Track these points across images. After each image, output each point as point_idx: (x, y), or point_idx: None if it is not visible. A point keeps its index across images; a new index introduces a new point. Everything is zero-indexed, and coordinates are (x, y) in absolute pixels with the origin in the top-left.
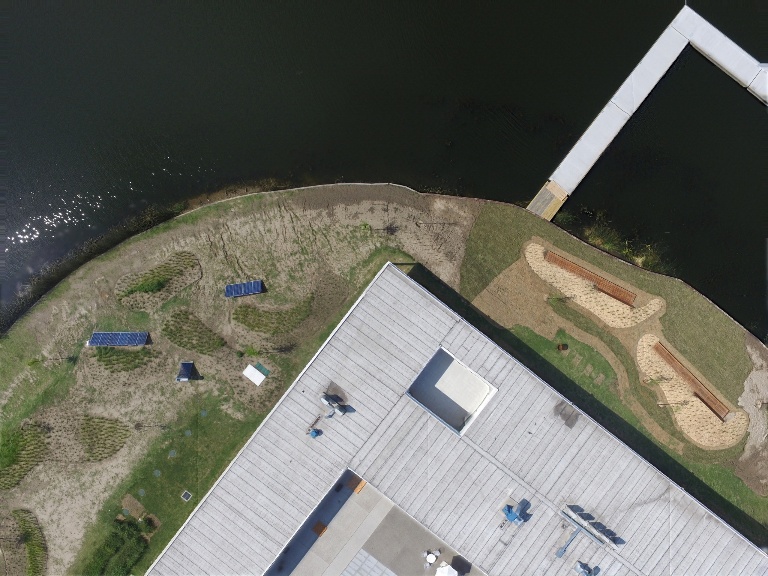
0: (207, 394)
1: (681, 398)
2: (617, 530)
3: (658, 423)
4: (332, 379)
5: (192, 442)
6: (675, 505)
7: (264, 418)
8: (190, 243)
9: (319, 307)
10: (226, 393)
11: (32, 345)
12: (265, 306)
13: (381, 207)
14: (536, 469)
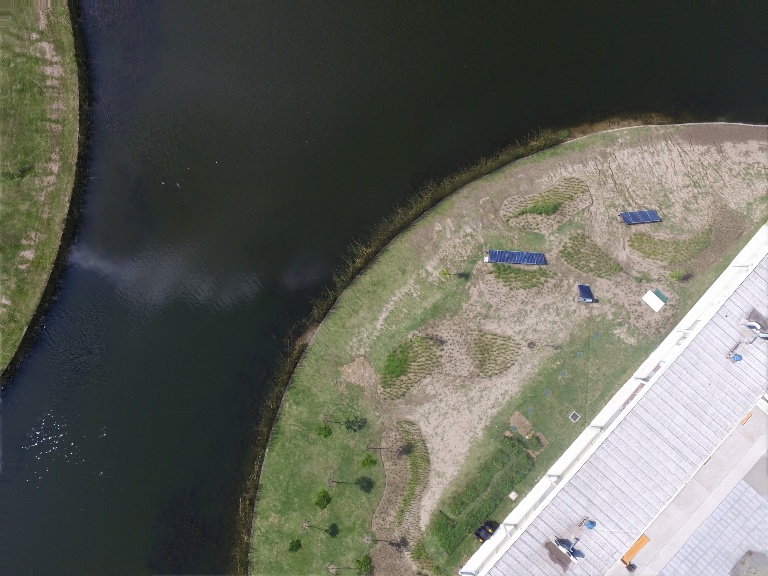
0: (601, 317)
1: None
2: None
3: None
4: (754, 306)
5: (584, 364)
6: None
7: (657, 345)
8: (578, 170)
9: (717, 239)
10: (621, 317)
11: (415, 260)
12: (660, 235)
13: None
14: None
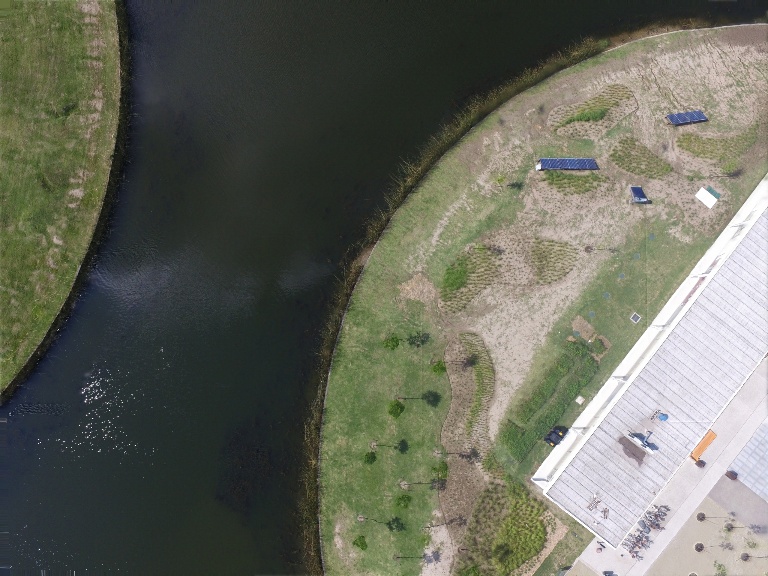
0: (655, 218)
1: None
2: None
3: None
4: None
5: (641, 265)
6: None
7: (712, 242)
8: (621, 77)
9: (764, 134)
10: (675, 217)
11: (466, 175)
12: (708, 134)
13: None
14: None
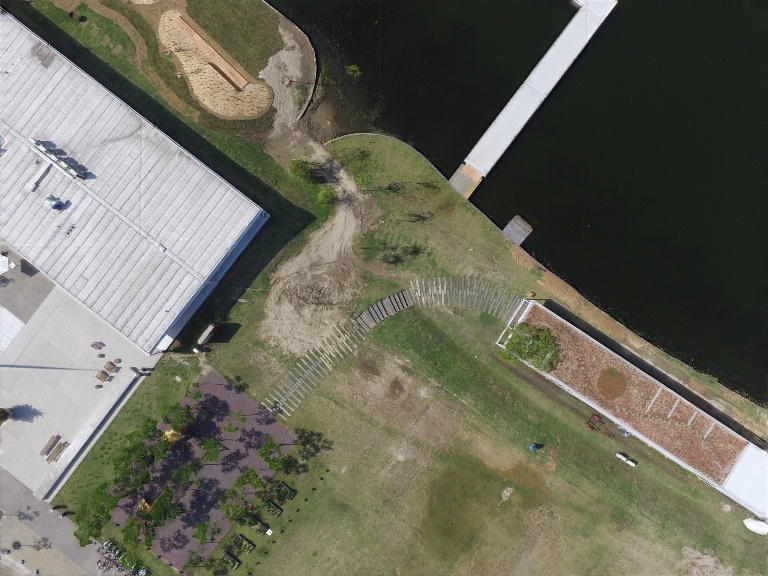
0: None
1: (196, 67)
2: (89, 165)
3: (175, 92)
4: None
5: None
6: (147, 142)
7: None
8: None
9: None
10: None
11: None
12: None
13: None
14: (11, 106)
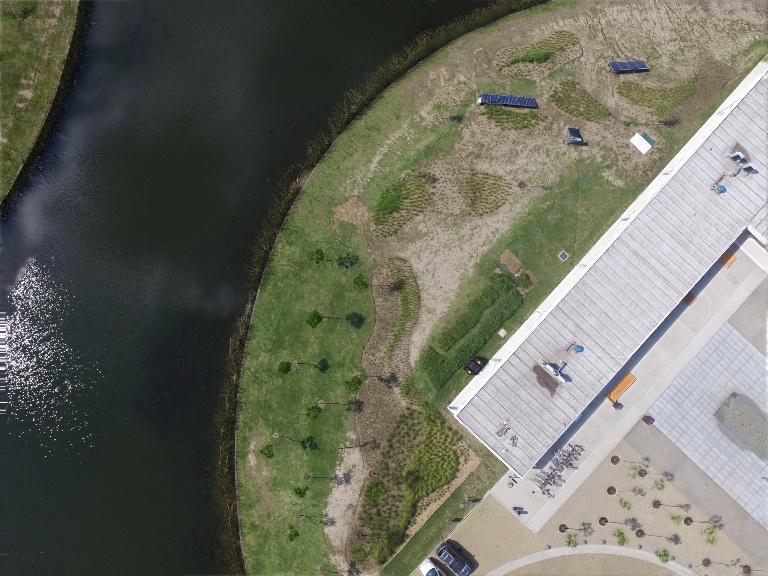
0: (590, 160)
1: None
2: None
3: None
4: (738, 141)
5: (573, 204)
6: None
7: (644, 187)
8: (569, 24)
9: (702, 88)
10: (610, 160)
11: (409, 106)
12: (648, 84)
13: (752, 8)
14: None
